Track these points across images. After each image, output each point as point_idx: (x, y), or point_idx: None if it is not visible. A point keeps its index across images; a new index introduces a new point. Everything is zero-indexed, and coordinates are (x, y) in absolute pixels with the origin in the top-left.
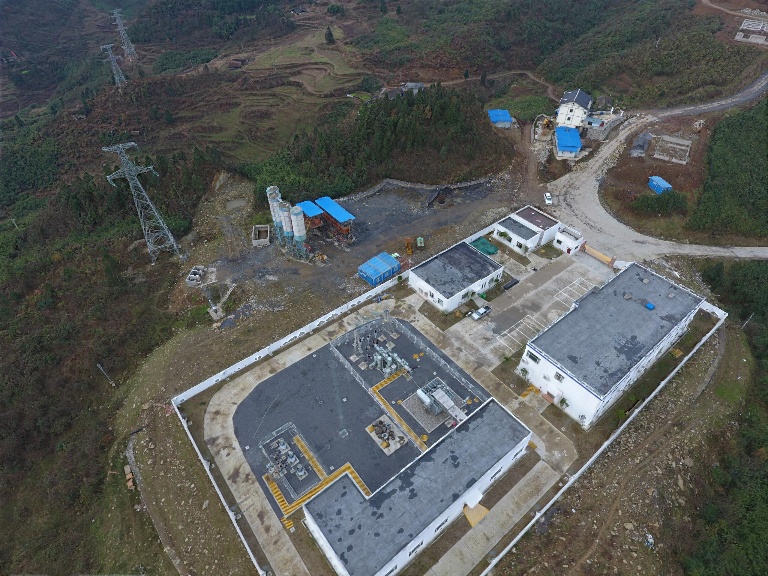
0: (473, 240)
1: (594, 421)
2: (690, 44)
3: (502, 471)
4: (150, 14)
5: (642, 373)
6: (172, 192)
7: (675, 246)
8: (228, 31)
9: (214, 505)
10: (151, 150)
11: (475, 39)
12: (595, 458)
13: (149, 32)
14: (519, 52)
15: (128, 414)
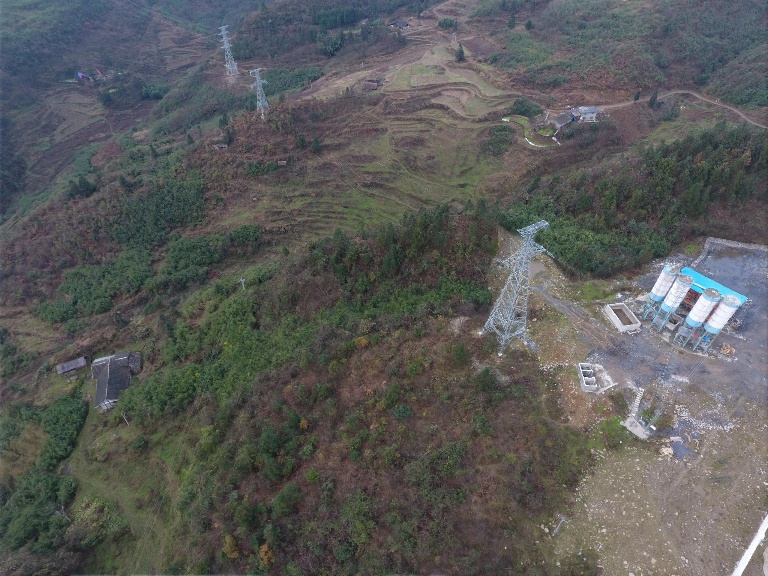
0: None
1: None
2: None
3: None
4: (249, 30)
5: None
6: (460, 255)
7: None
8: (333, 47)
9: None
10: (303, 182)
11: (638, 57)
12: None
13: (250, 49)
14: (679, 70)
15: None
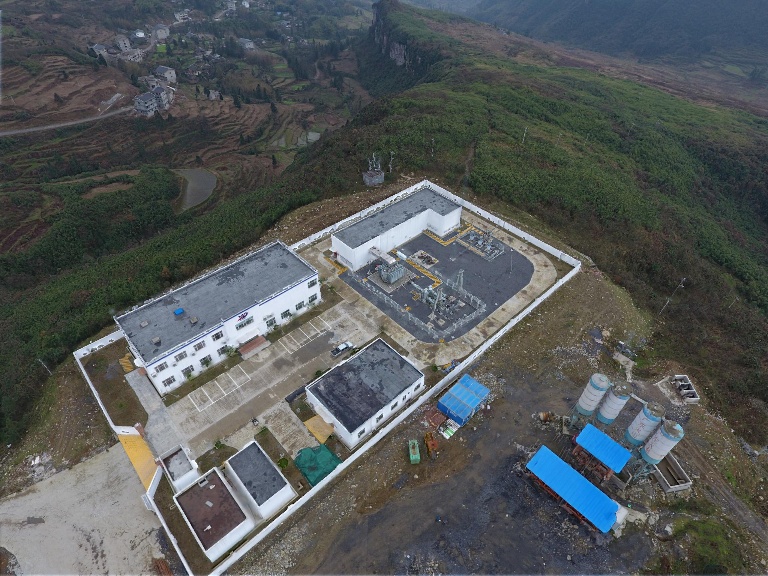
0: (330, 480)
1: None
2: None
3: None
4: None
5: None
6: None
7: None
8: None
9: None
10: None
11: None
12: None
13: None
14: None
15: None
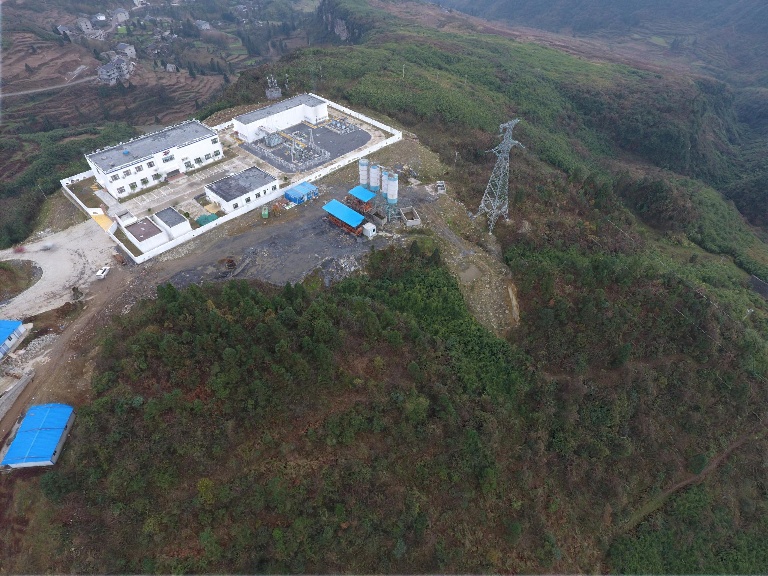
0: (215, 226)
1: None
2: None
3: None
4: None
5: None
6: None
7: (7, 256)
8: None
9: None
10: None
11: None
12: None
13: None
14: None
15: None
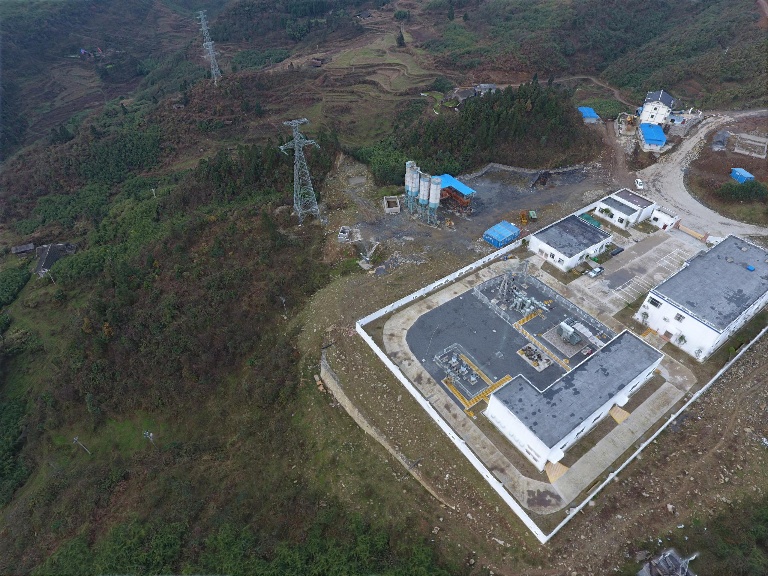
0: (577, 215)
1: (707, 356)
2: (759, 53)
3: (636, 387)
4: (228, 16)
5: (743, 324)
6: None
7: (757, 229)
8: (300, 33)
9: (407, 399)
10: (243, 138)
11: (543, 45)
12: (711, 383)
13: (227, 32)
14: (583, 58)
15: (310, 337)
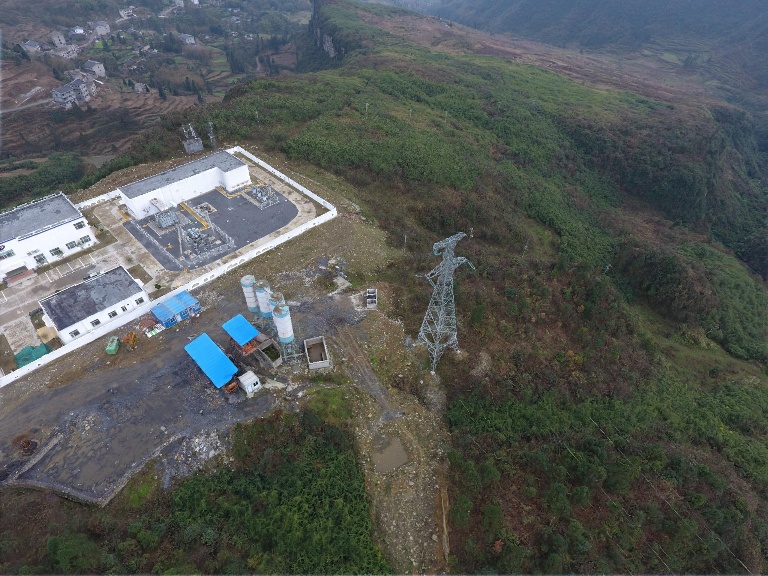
0: (37, 367)
1: None
2: None
3: None
4: None
5: None
6: None
7: None
8: None
9: None
10: None
11: None
12: None
13: None
14: None
15: None
